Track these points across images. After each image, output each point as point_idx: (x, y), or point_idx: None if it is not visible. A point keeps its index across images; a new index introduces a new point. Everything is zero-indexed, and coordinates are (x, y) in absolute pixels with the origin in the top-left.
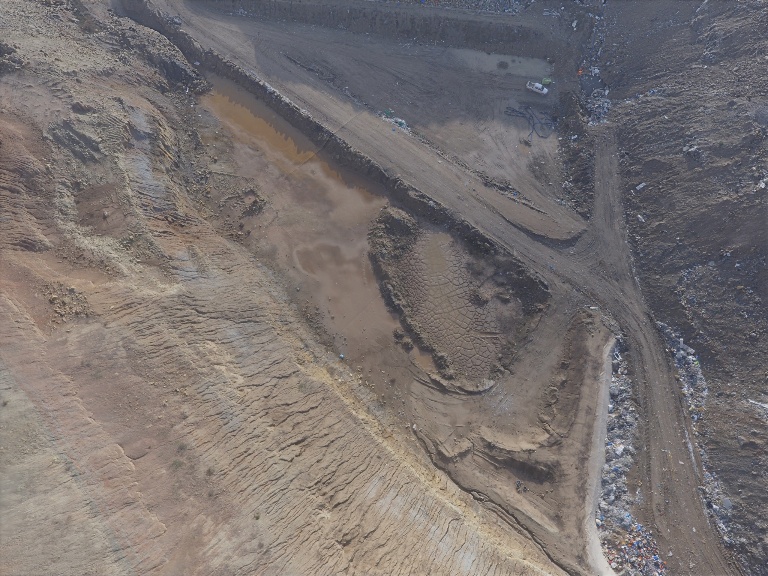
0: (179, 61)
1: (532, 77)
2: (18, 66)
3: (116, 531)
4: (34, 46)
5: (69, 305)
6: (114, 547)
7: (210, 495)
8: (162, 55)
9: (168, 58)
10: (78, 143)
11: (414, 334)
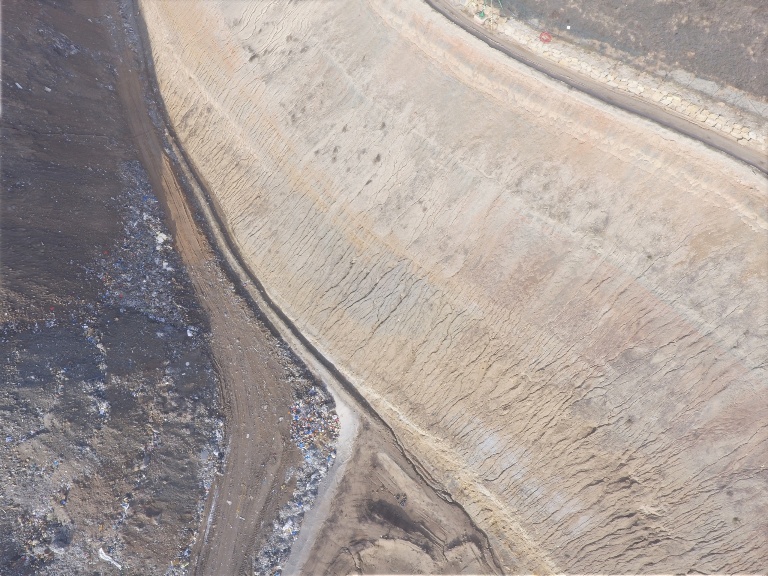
0: None
1: None
2: None
3: None
4: None
5: None
6: None
7: None
8: None
9: None
10: None
11: None
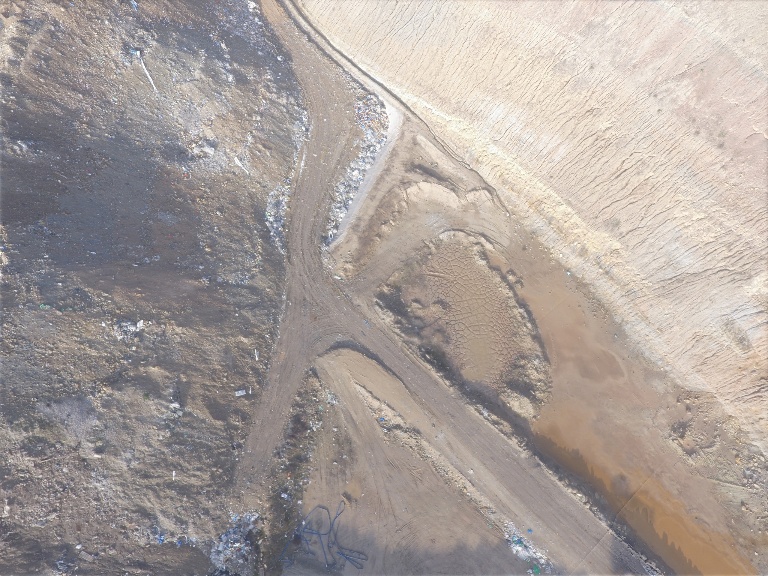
0: None
1: None
2: None
3: (759, 81)
4: None
5: None
6: (759, 72)
7: (694, 120)
8: None
9: None
10: None
11: (506, 282)
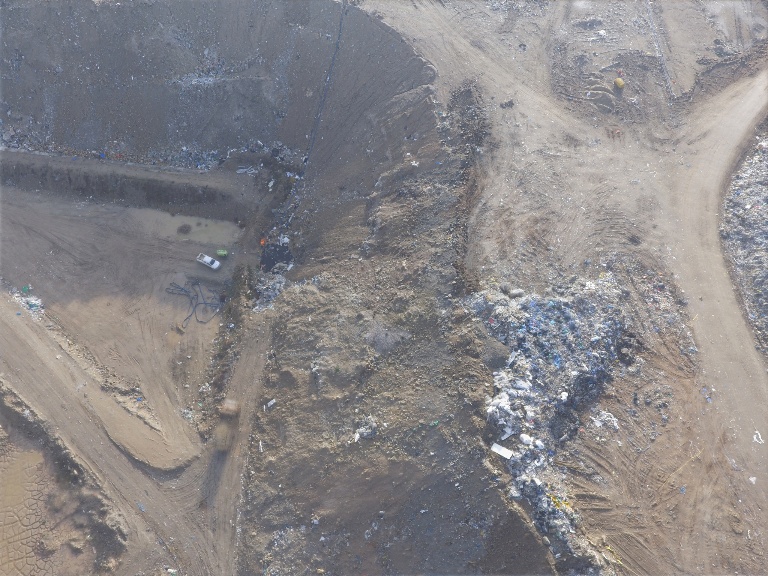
0: None
1: (211, 245)
2: None
3: None
4: None
5: None
6: None
7: None
8: None
9: None
10: None
11: None
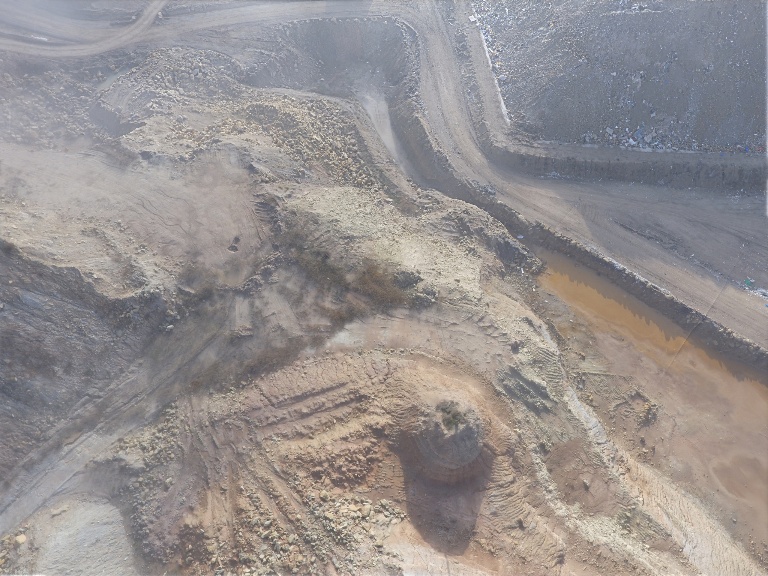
0: (509, 239)
1: None
2: (432, 298)
3: None
4: (423, 264)
5: None
6: None
7: None
8: (497, 236)
9: (501, 238)
10: (529, 392)
11: None
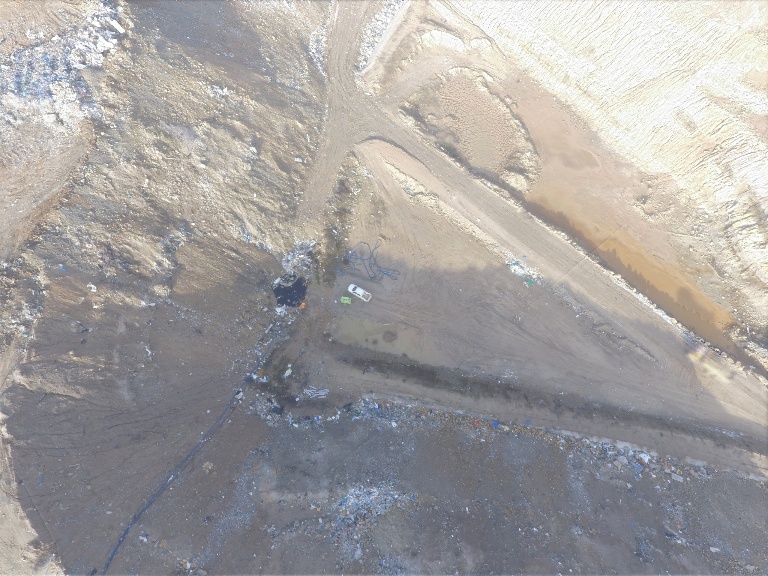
0: None
1: (359, 314)
2: None
3: None
4: None
5: (767, 37)
6: None
7: None
8: None
9: None
10: None
11: None
